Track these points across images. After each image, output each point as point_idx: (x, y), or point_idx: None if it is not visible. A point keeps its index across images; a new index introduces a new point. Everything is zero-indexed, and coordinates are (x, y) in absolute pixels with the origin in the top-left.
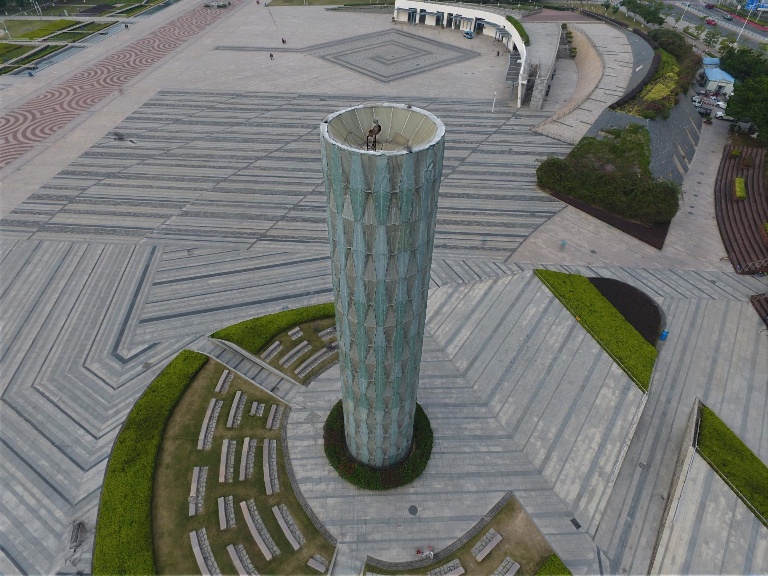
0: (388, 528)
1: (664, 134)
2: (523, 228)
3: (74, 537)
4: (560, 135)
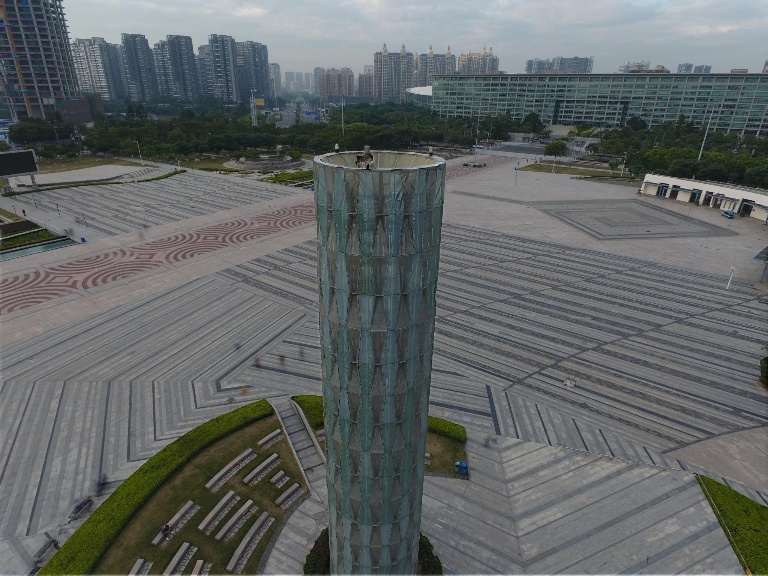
0: None
1: None
2: (712, 423)
3: (77, 508)
4: None
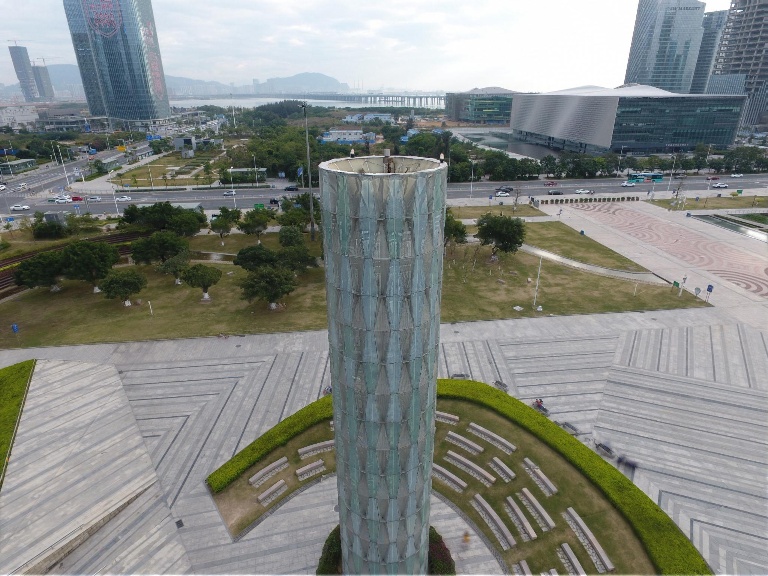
0: None
1: None
2: None
3: None
4: None
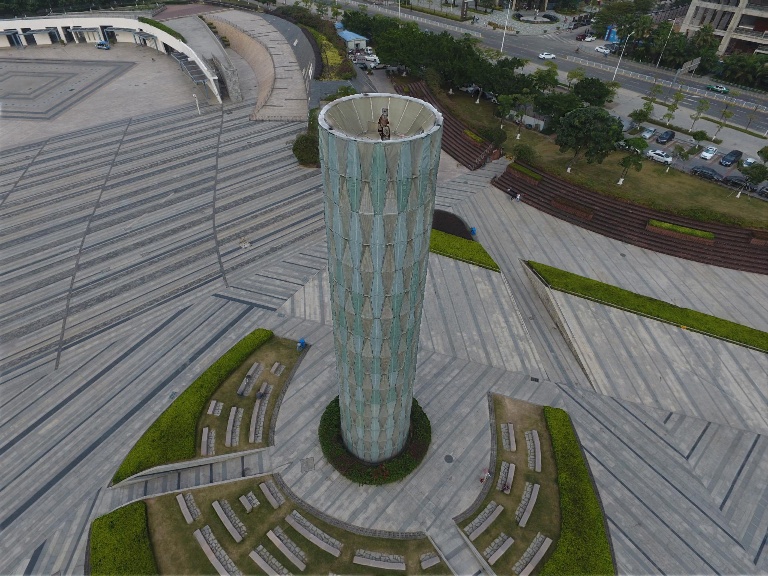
0: (446, 487)
1: (362, 89)
2: (321, 203)
3: None
4: (281, 116)
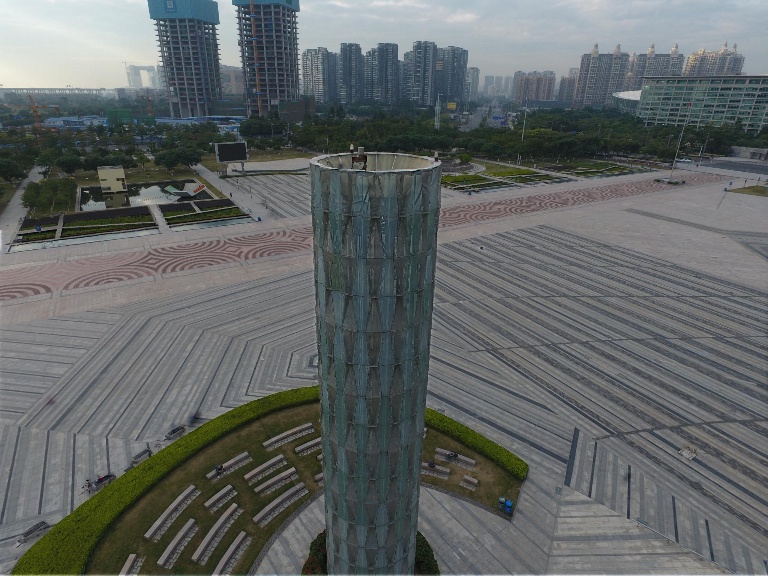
0: None
1: None
2: None
3: (172, 431)
4: None
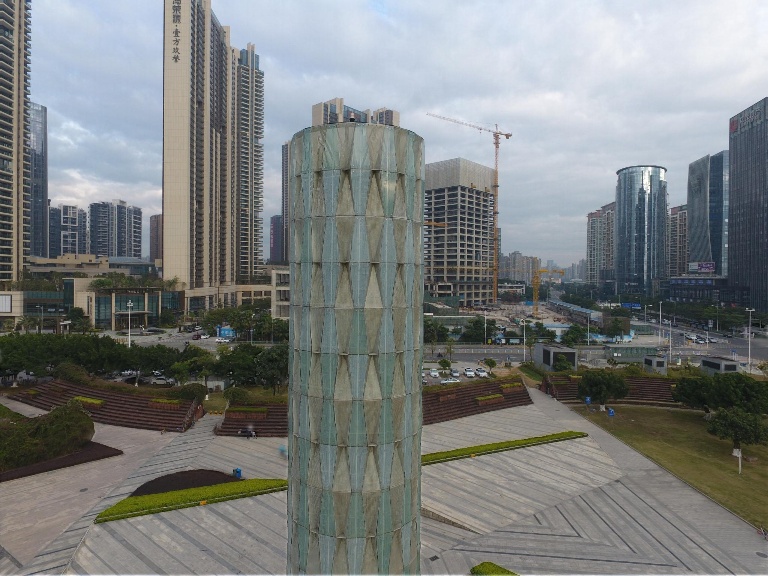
0: None
1: None
2: None
3: None
4: None
